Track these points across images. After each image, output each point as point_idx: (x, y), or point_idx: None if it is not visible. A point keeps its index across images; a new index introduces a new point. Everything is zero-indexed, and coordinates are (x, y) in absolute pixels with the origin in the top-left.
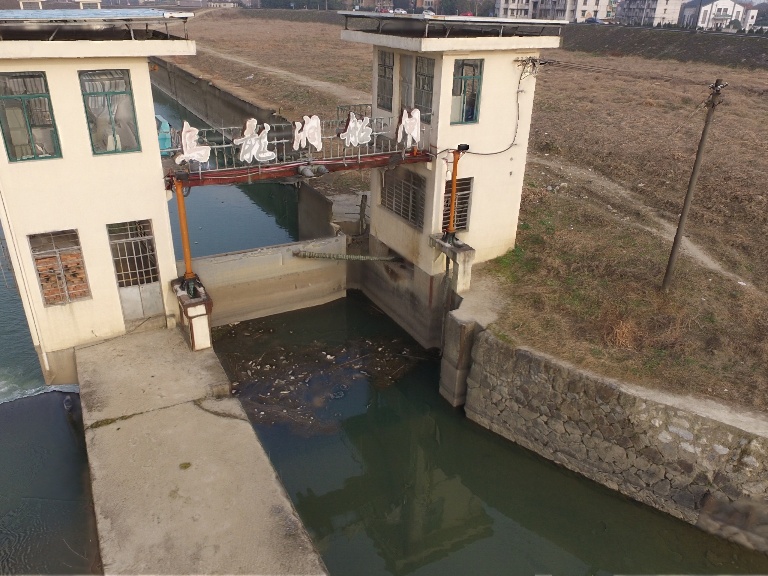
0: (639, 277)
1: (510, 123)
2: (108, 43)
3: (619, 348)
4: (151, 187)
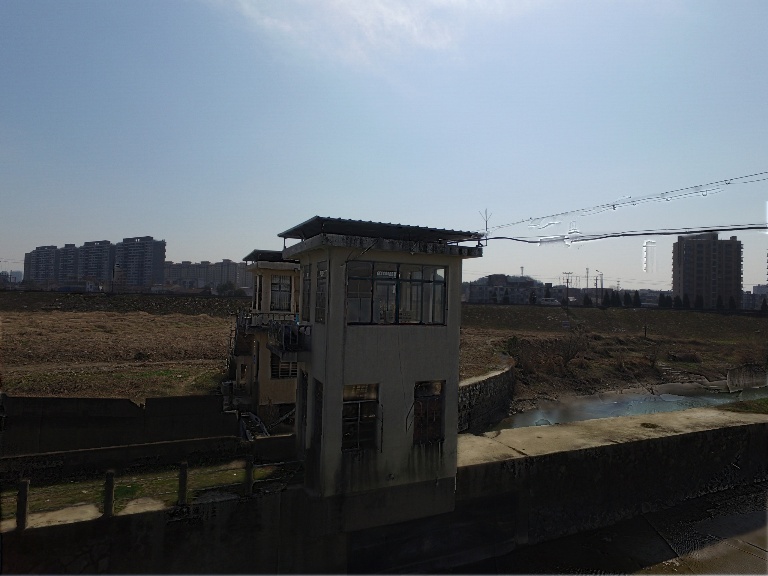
0: None
1: None
2: None
3: None
4: None
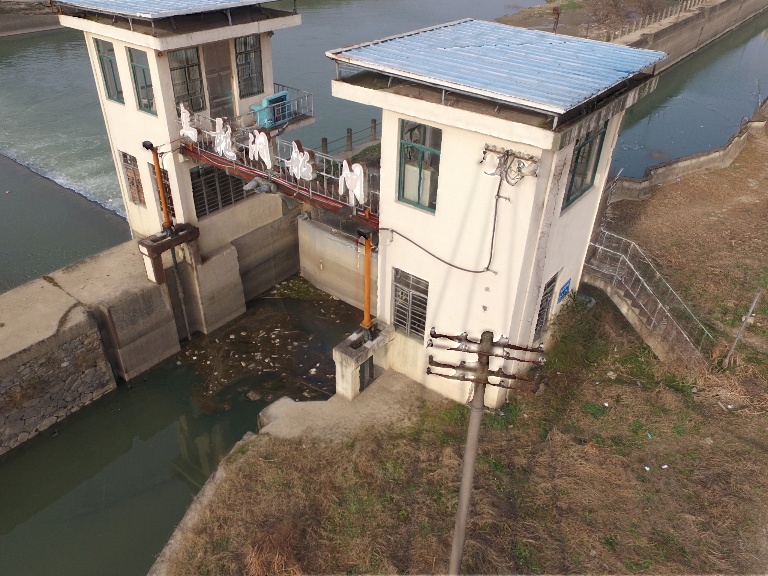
0: (471, 575)
1: (486, 237)
2: (119, 30)
3: (244, 572)
4: (165, 146)
